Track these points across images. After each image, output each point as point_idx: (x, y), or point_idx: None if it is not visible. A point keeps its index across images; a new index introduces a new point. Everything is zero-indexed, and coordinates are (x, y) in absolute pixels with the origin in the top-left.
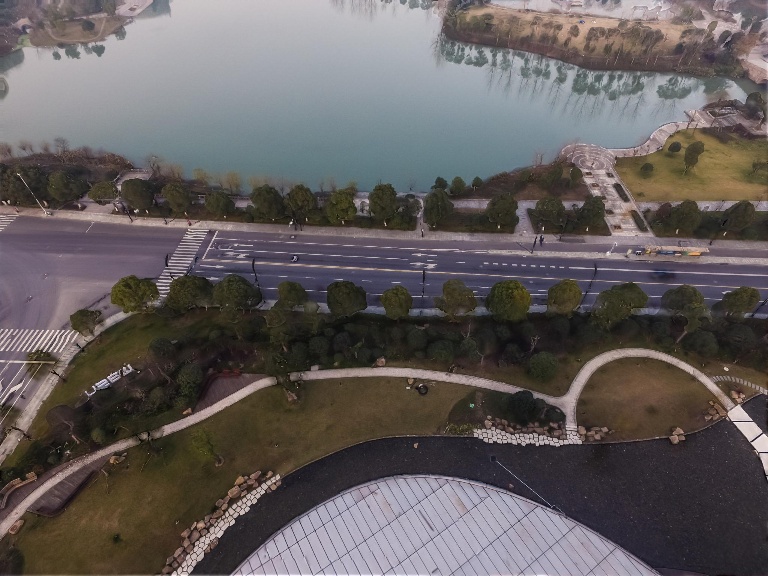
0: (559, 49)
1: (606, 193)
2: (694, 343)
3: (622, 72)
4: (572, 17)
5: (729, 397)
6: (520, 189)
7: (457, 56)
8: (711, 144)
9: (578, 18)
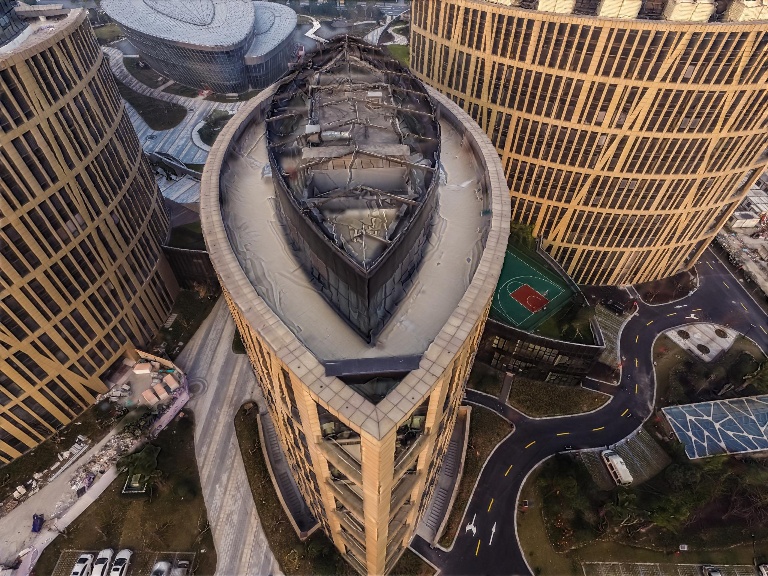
0: None
1: None
2: (311, 8)
3: None
4: None
5: (316, 20)
6: None
7: None
8: None
9: None
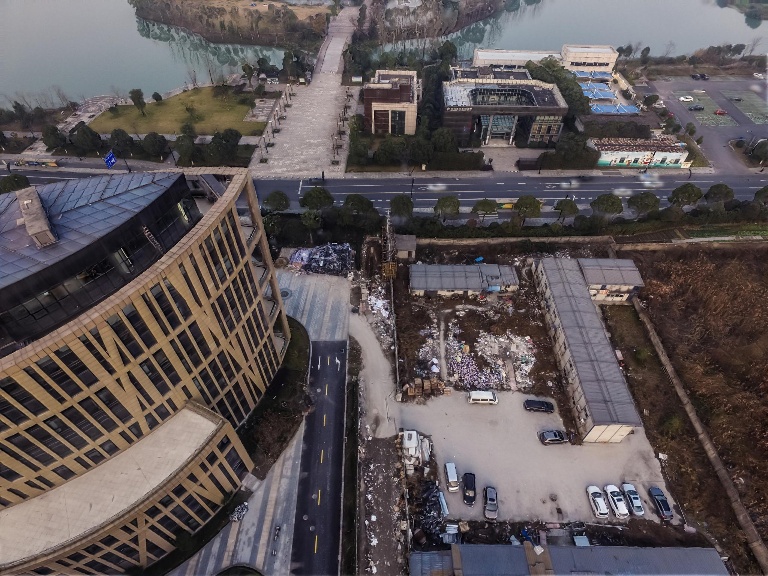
0: (201, 26)
1: (65, 128)
2: None
3: (241, 46)
4: (256, 1)
5: None
6: (2, 124)
7: (145, 31)
8: (204, 97)
9: (258, 2)
